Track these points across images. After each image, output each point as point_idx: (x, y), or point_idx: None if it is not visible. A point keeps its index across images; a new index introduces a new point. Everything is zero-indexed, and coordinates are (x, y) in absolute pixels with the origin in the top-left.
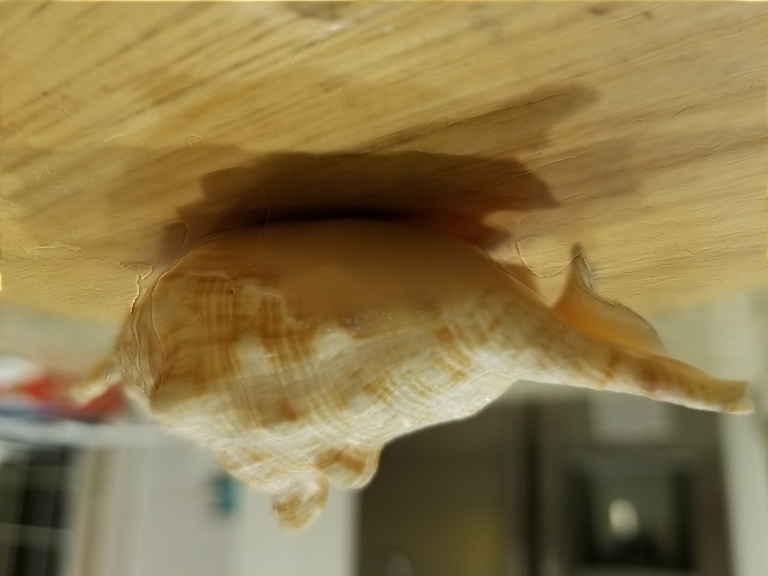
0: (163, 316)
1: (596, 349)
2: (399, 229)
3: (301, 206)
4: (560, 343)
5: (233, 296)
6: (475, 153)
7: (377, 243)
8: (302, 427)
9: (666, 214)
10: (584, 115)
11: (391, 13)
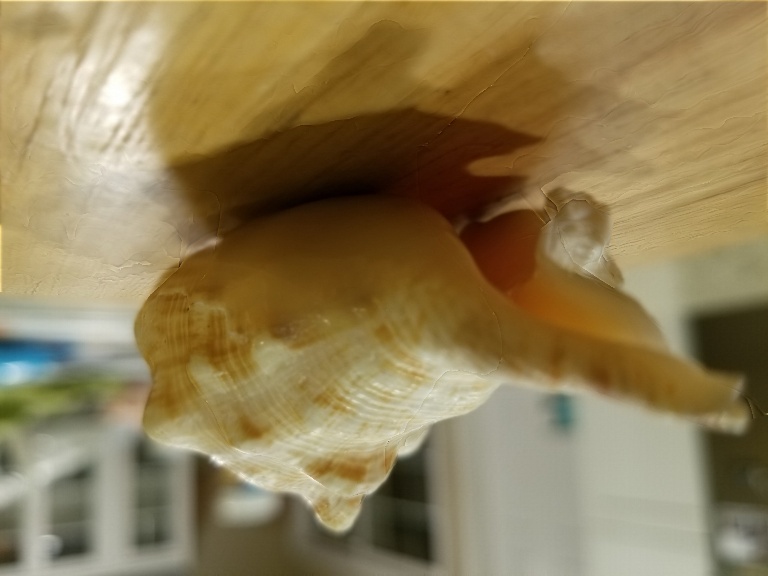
0: (142, 340)
1: (537, 342)
2: (343, 211)
3: (244, 205)
4: (490, 339)
5: (188, 314)
6: (367, 112)
7: (319, 232)
8: (271, 443)
9: (719, 112)
10: (445, 36)
11: (87, 1)
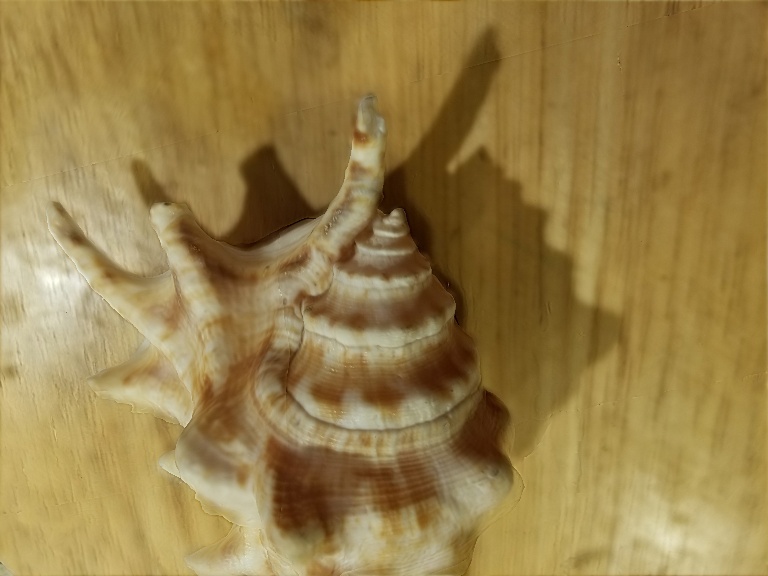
0: None
1: None
2: None
3: None
4: None
5: None
6: None
7: None
8: None
9: None
10: None
11: (554, 573)
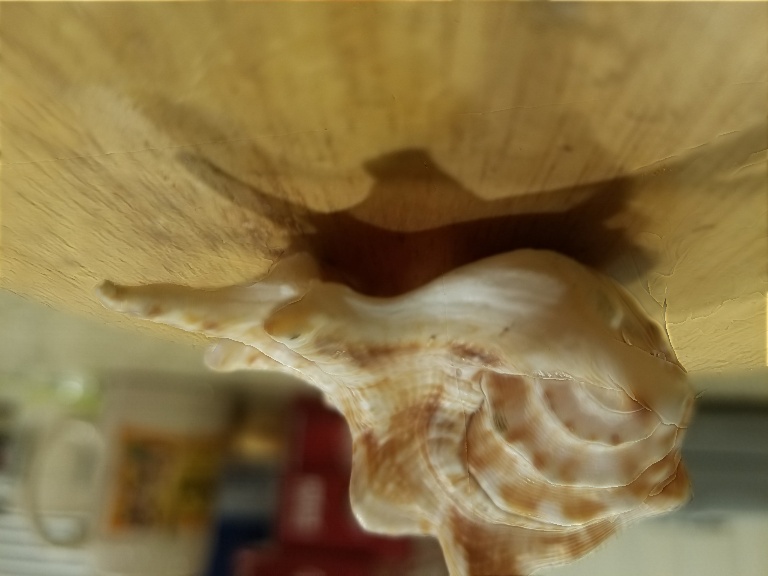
0: None
1: None
2: None
3: None
4: None
5: None
6: None
7: None
8: None
9: None
10: None
11: None
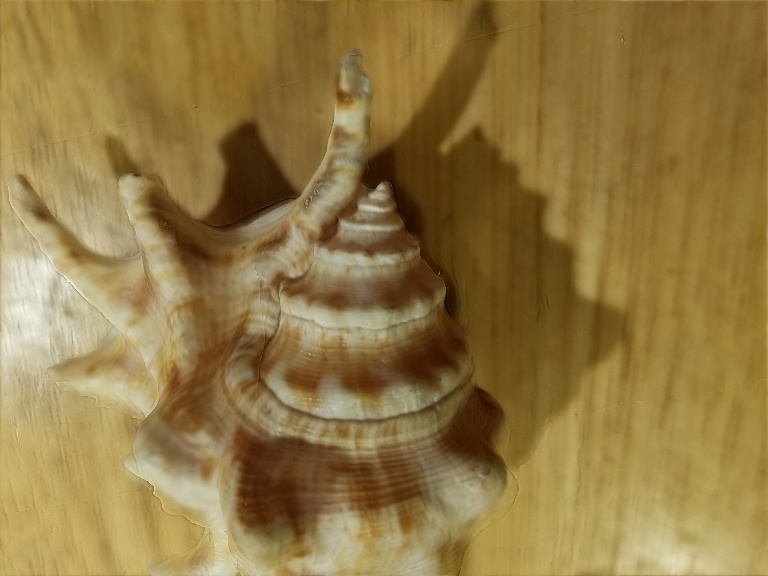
0: None
1: None
2: None
3: None
4: None
5: None
6: None
7: None
8: None
9: None
10: None
11: None
